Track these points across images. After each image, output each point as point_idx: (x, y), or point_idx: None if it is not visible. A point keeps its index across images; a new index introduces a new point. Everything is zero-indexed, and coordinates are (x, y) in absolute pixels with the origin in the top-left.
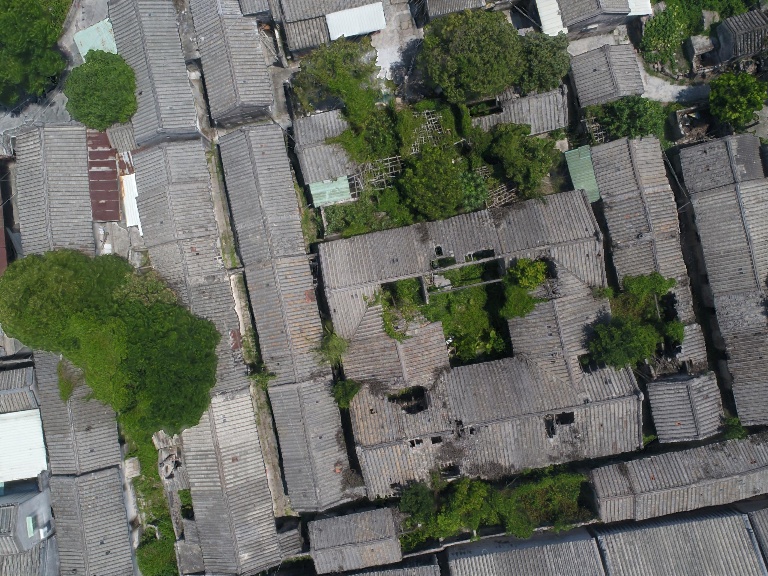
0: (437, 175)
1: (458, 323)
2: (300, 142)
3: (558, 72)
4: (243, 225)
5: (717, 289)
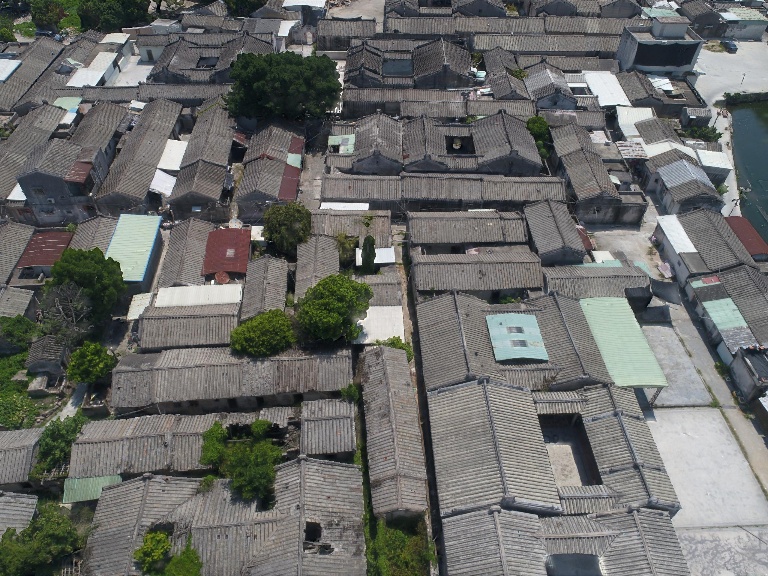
0: None
1: None
2: None
3: None
4: None
5: (236, 393)
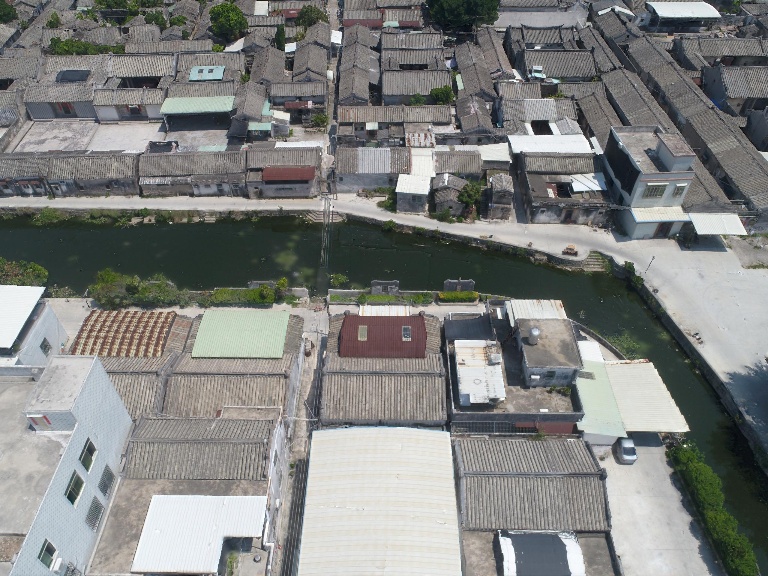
0: None
1: None
2: None
3: None
4: (47, 7)
5: None
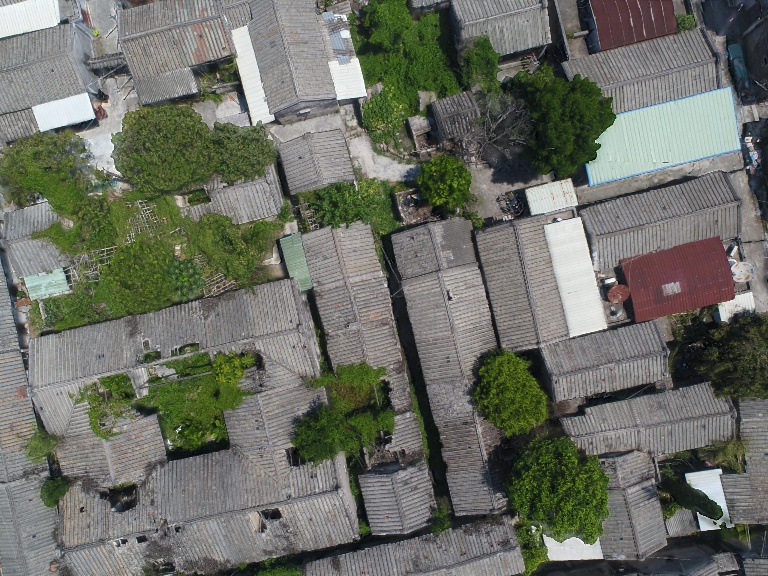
0: (133, 271)
1: (191, 410)
2: (7, 237)
3: (255, 163)
4: None
5: (429, 377)
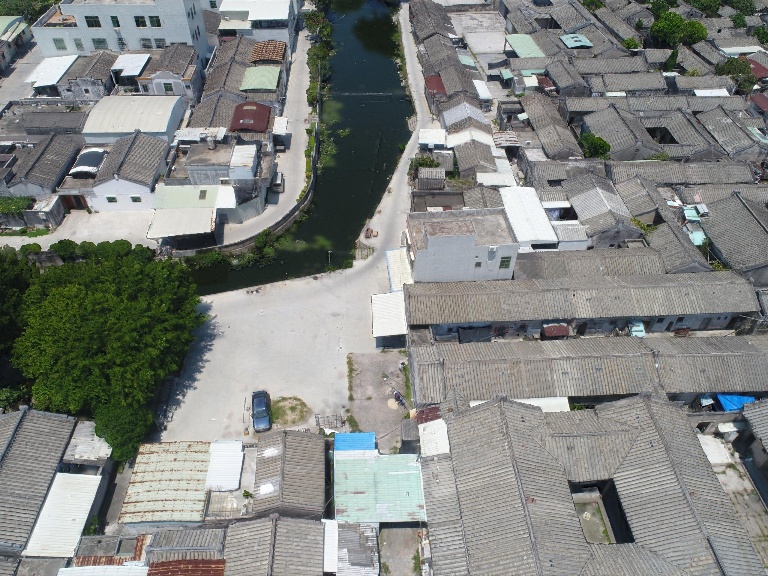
0: None
1: None
2: None
3: (743, 6)
4: None
5: None
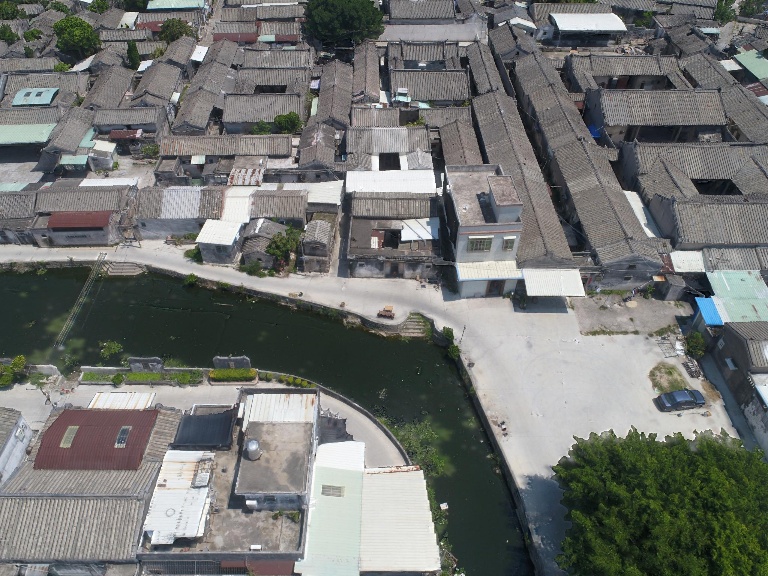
0: None
1: None
2: None
3: None
4: None
5: None
